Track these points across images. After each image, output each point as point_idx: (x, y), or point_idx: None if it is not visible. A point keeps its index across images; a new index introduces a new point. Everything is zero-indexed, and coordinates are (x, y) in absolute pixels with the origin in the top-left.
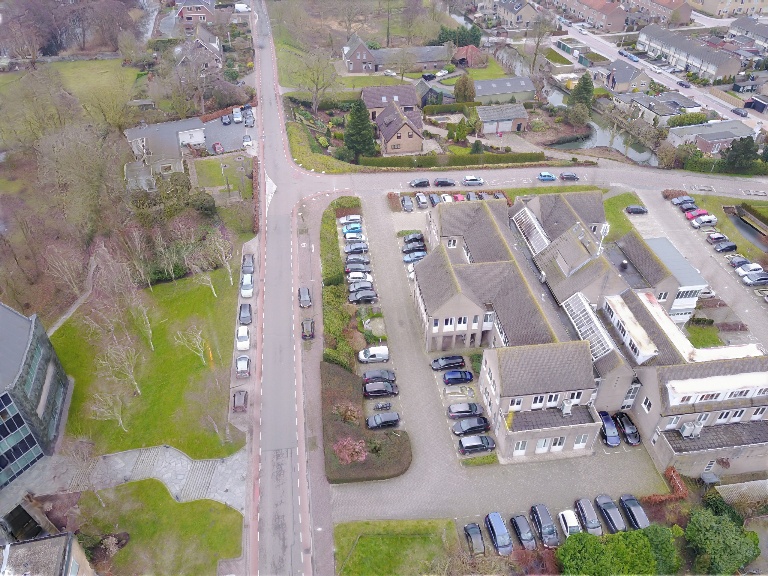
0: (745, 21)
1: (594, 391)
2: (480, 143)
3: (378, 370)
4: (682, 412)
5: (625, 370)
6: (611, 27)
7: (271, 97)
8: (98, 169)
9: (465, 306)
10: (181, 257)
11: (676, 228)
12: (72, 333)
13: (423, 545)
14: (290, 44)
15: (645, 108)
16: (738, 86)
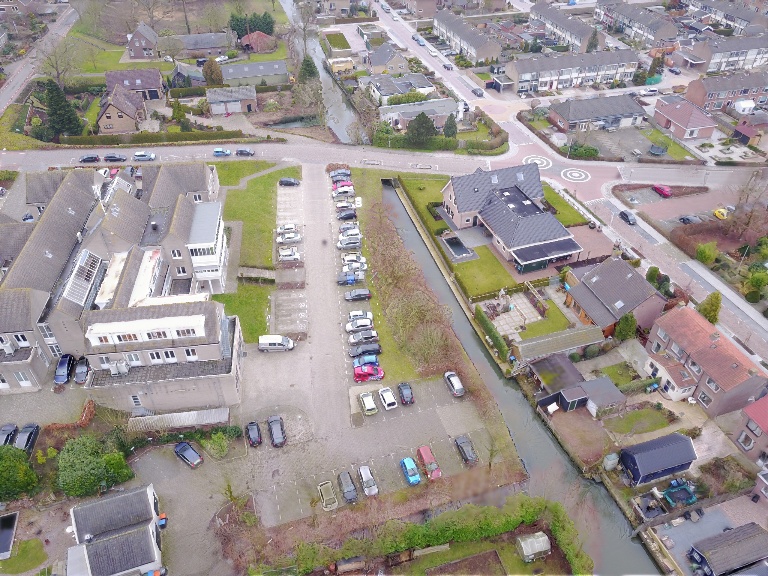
0: (541, 5)
1: (51, 335)
2: (185, 122)
3: None
4: (103, 351)
5: (63, 315)
6: (423, 13)
7: (19, 82)
8: None
9: None
10: None
11: (317, 199)
12: None
13: None
14: (84, 32)
15: (375, 89)
16: (492, 67)
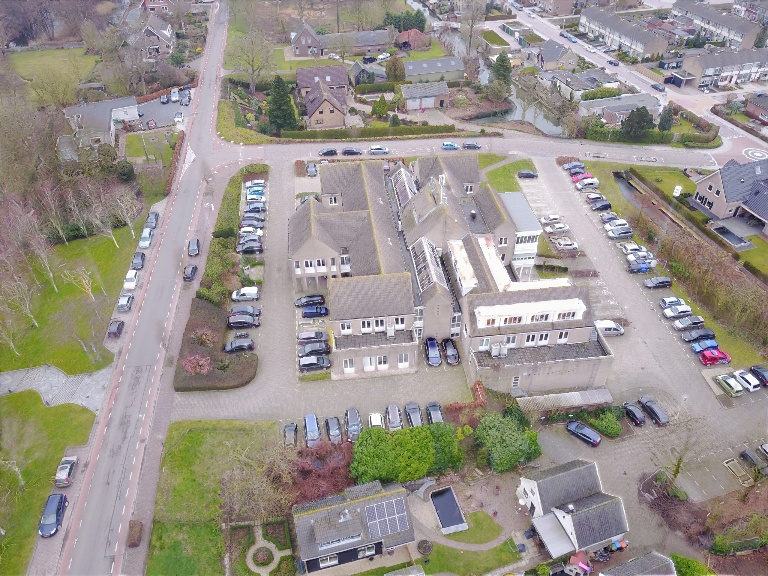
0: (686, 2)
1: (420, 319)
2: (396, 117)
3: (246, 306)
4: (488, 334)
5: (442, 299)
6: (559, 10)
7: (212, 79)
8: (19, 137)
9: (320, 249)
10: (94, 215)
11: (561, 190)
12: None
13: (246, 439)
14: (243, 31)
15: (563, 84)
16: (663, 63)
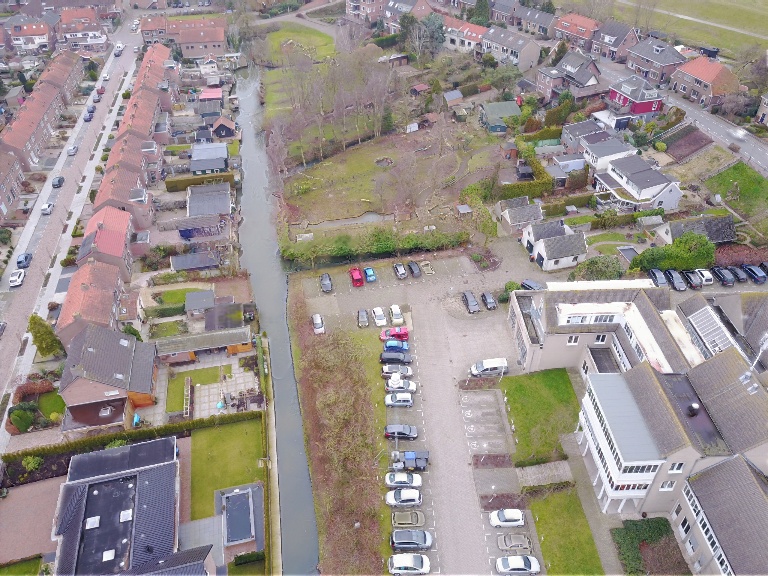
0: None
1: None
2: None
3: None
4: None
5: None
6: None
7: None
8: None
9: None
10: None
11: None
12: None
13: None
14: None
15: None
16: None
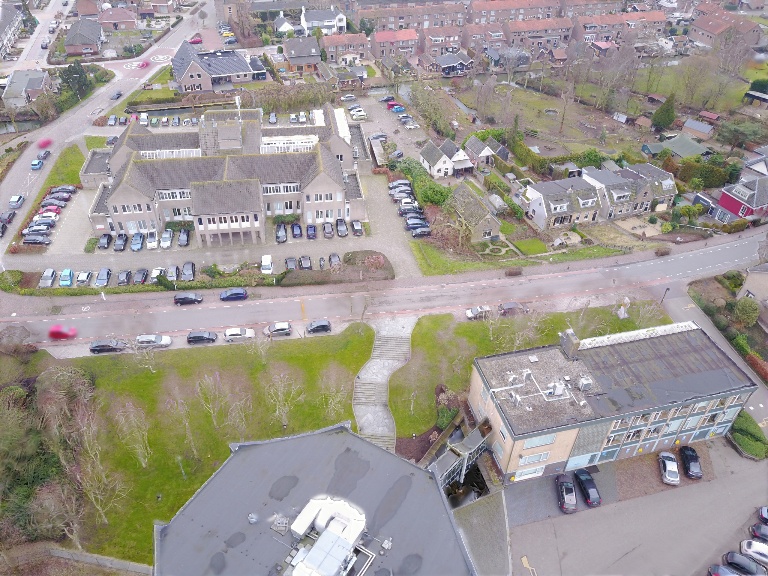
0: None
1: None
2: None
3: None
4: (352, 145)
5: None
6: None
7: None
8: None
9: None
10: None
11: None
12: (150, 539)
13: (427, 251)
14: None
15: None
16: None
